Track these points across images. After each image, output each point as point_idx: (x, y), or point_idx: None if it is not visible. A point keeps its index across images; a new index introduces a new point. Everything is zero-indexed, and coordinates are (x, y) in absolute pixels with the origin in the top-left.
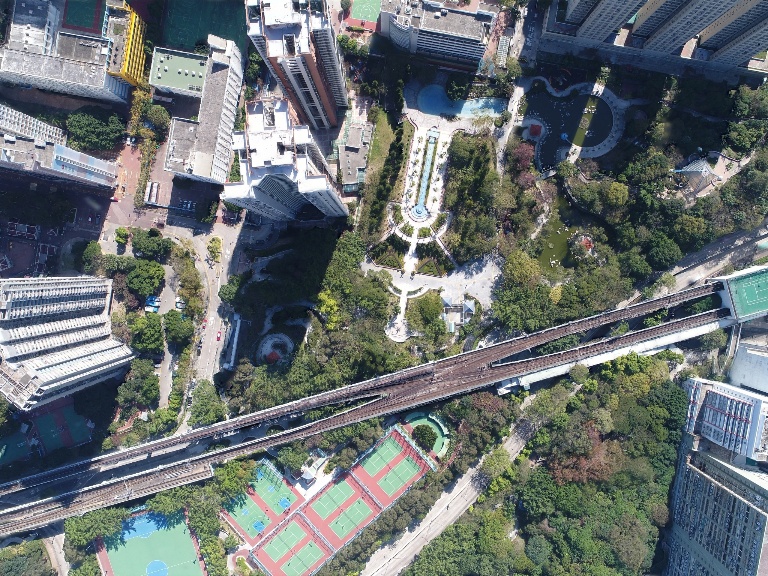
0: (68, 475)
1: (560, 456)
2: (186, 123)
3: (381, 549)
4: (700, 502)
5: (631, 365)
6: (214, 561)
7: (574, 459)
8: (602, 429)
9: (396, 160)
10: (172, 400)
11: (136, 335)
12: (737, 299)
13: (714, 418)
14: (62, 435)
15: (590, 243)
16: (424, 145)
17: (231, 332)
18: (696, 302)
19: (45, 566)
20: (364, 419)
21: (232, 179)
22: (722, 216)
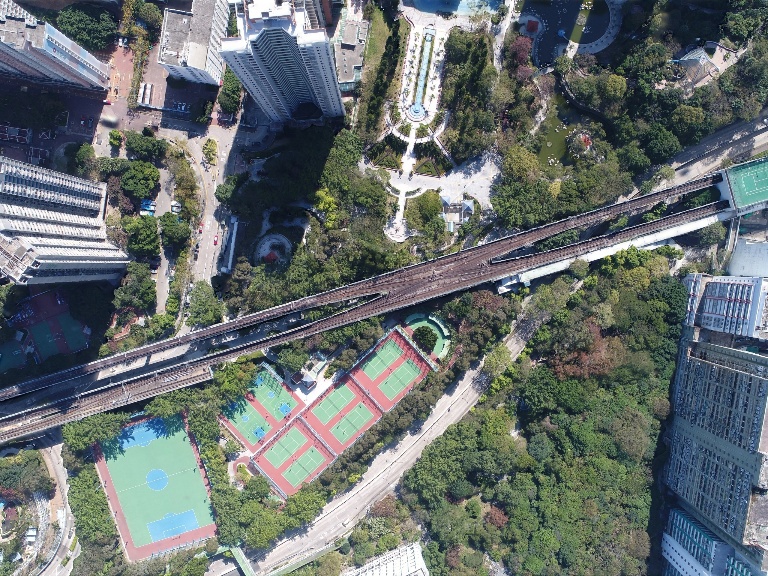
0: (65, 380)
1: (561, 351)
2: (179, 15)
3: (383, 453)
4: (701, 388)
5: (631, 258)
6: (215, 466)
7: (575, 353)
8: (603, 324)
9: (393, 55)
10: (169, 303)
11: (132, 235)
12: (736, 188)
13: (714, 307)
14: (58, 343)
15: (588, 140)
16: (421, 43)
17: (228, 236)
18: (695, 196)
19: (43, 473)
20: (364, 318)
21: (227, 76)
22: (720, 105)
